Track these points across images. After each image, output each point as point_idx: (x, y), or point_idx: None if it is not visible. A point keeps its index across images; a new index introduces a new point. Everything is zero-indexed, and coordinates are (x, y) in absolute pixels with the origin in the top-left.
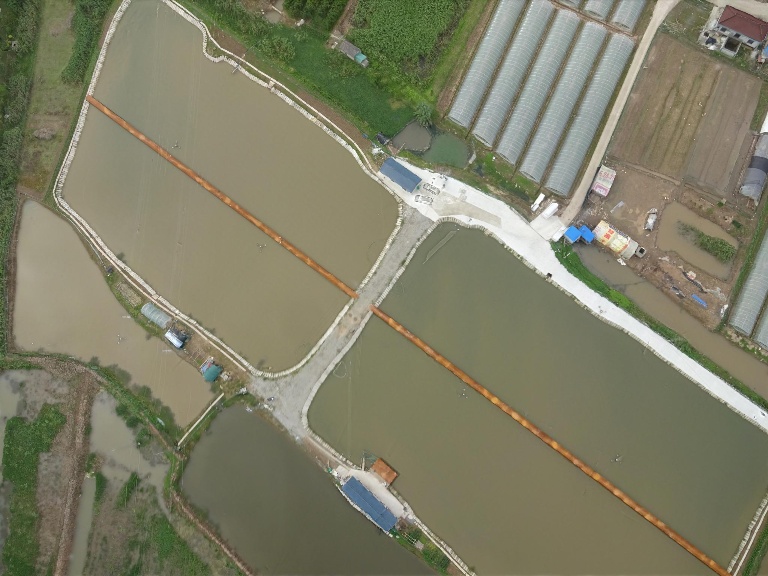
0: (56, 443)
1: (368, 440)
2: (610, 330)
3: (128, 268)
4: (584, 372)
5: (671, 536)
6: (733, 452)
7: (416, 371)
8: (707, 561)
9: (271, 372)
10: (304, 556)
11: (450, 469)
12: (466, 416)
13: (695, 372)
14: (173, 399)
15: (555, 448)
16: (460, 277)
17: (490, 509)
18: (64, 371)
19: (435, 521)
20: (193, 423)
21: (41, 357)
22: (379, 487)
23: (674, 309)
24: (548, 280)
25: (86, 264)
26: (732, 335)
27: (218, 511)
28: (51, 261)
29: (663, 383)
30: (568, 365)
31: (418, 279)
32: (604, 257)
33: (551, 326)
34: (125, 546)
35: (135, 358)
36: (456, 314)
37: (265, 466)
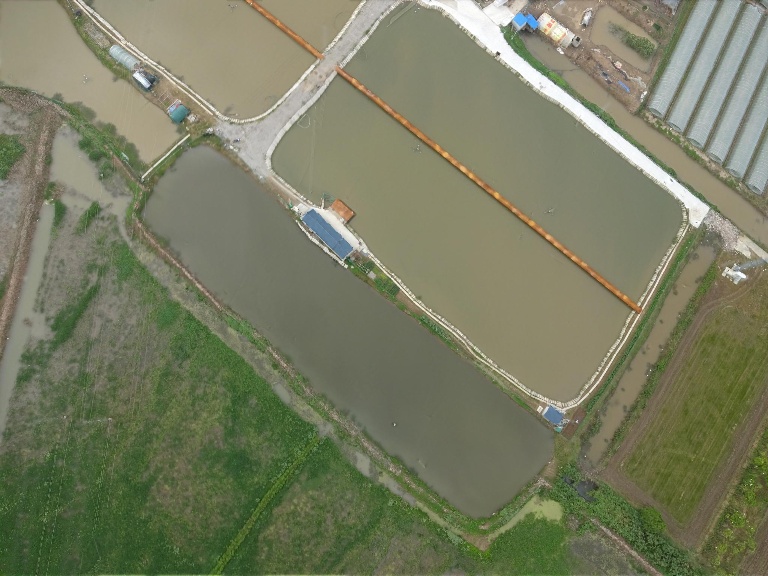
0: (14, 171)
1: (328, 182)
2: (548, 104)
3: (97, 14)
4: (524, 137)
5: (592, 275)
6: (646, 210)
7: (375, 127)
8: (621, 296)
9: (237, 119)
10: (263, 283)
11: (403, 212)
12: (419, 168)
13: (618, 143)
14: (138, 137)
15: (497, 198)
16: (419, 49)
17: (437, 248)
18: (25, 104)
19: (387, 256)
20: (158, 159)
21: (1, 88)
22: (337, 224)
23: (602, 93)
24: (497, 58)
25: (52, 7)
26: (649, 116)
27: (180, 241)
28: (15, 1)
29: (591, 151)
30: (511, 131)
31: (380, 48)
32: (545, 46)
33: (498, 97)
34: (83, 268)
35: (101, 97)
36: (414, 81)
37: (228, 202)
